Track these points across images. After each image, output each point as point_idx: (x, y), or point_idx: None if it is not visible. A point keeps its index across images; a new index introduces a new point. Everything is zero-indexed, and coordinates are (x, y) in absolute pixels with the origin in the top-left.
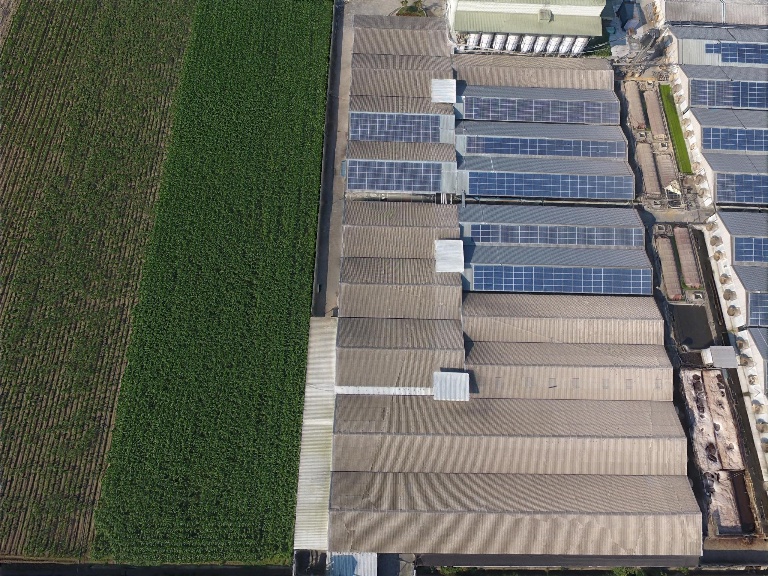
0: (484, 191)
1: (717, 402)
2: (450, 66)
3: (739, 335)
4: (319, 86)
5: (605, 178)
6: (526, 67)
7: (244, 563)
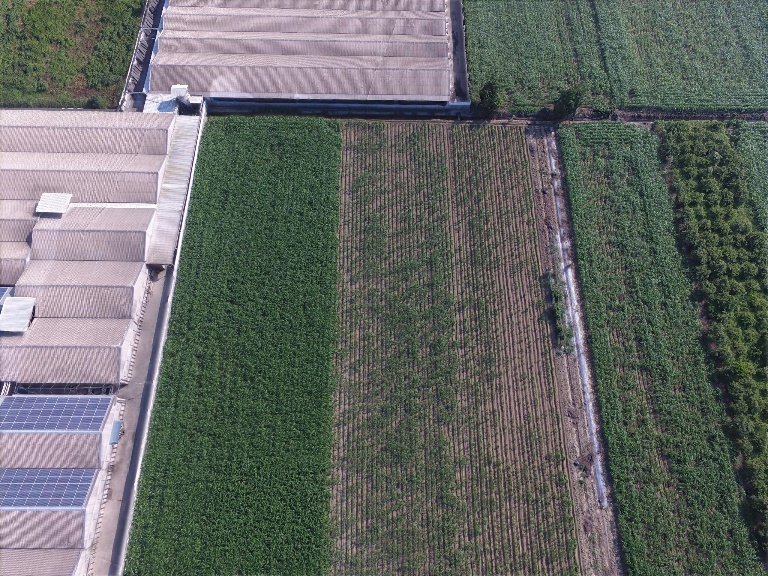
0: None
1: None
2: None
3: None
4: None
5: None
6: None
7: None
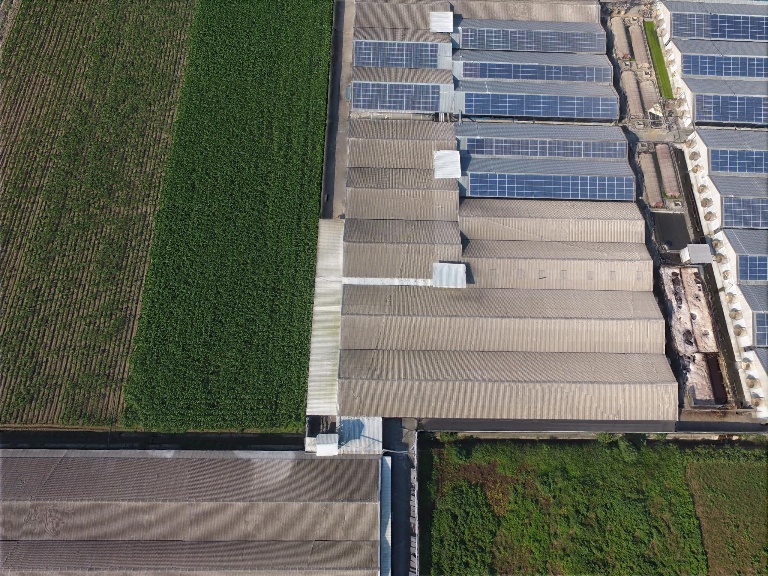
0: (479, 111)
1: (694, 295)
2: (447, 1)
3: (715, 237)
4: (325, 21)
5: (592, 99)
6: (518, 2)
7: (261, 431)
